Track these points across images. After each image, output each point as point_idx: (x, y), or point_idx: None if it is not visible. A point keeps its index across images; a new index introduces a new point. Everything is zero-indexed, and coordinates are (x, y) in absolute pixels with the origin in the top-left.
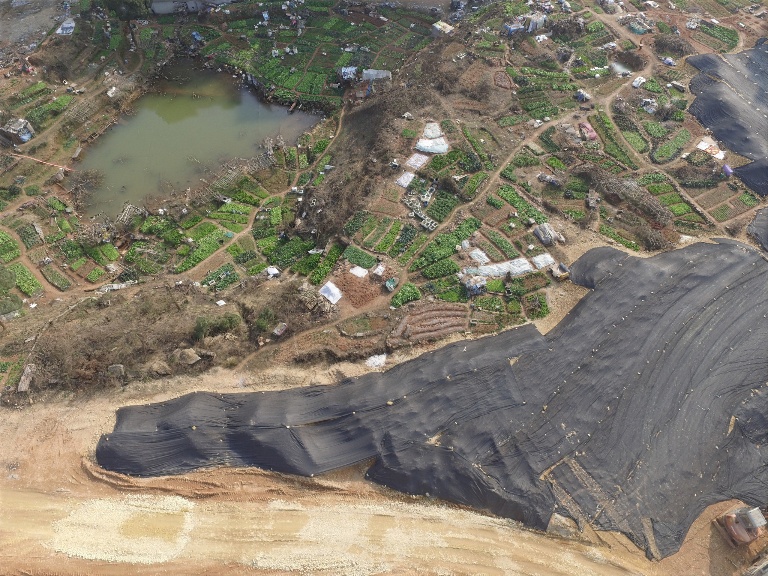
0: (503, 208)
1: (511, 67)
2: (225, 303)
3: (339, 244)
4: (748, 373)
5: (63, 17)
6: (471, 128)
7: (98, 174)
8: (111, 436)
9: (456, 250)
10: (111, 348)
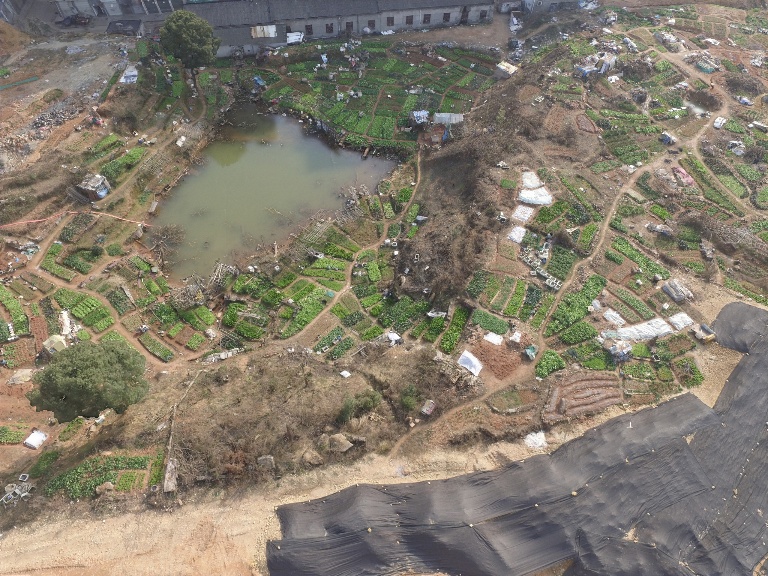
0: (624, 263)
1: (590, 110)
2: (350, 374)
3: (462, 306)
4: None
5: (122, 64)
6: (567, 176)
7: (178, 229)
8: (282, 544)
9: (589, 311)
10: (253, 436)
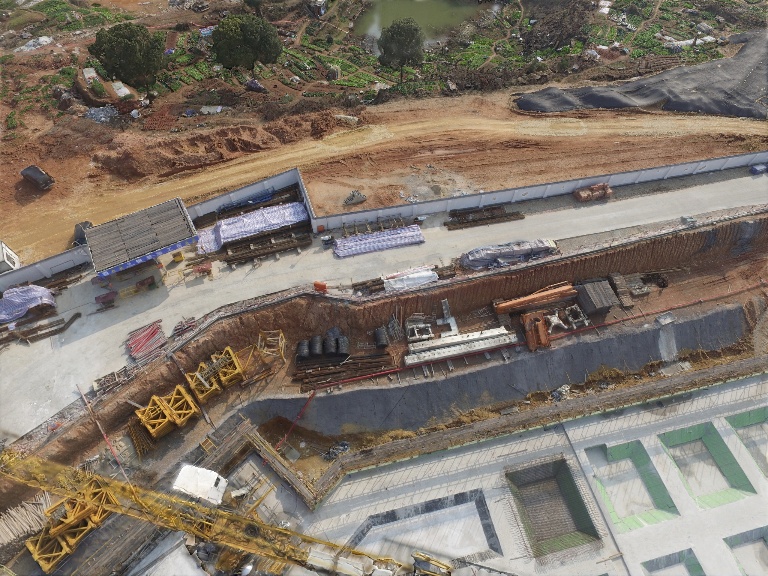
0: (672, 20)
1: None
2: None
3: None
4: None
5: None
6: None
7: (372, 35)
8: (523, 96)
9: (655, 37)
10: None
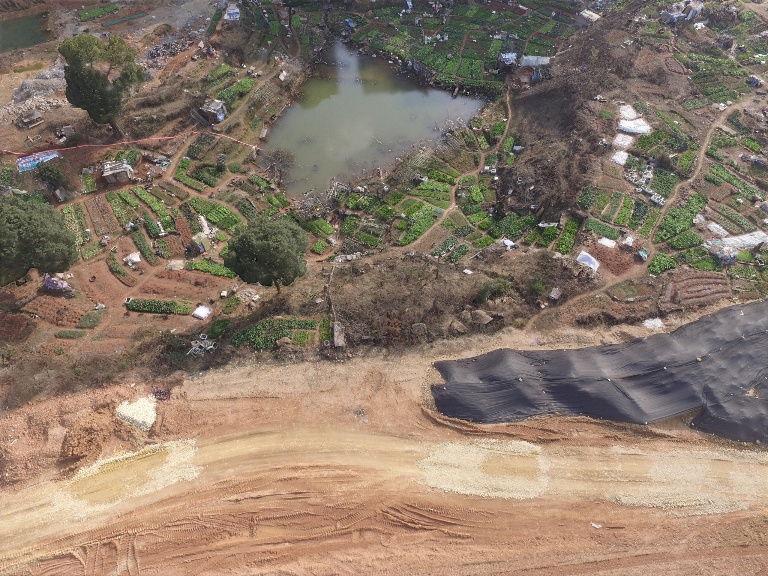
0: (723, 185)
1: (678, 53)
2: (472, 272)
3: (573, 217)
4: None
5: (221, 3)
6: (661, 111)
7: (289, 153)
8: (447, 386)
9: (694, 223)
10: (404, 309)
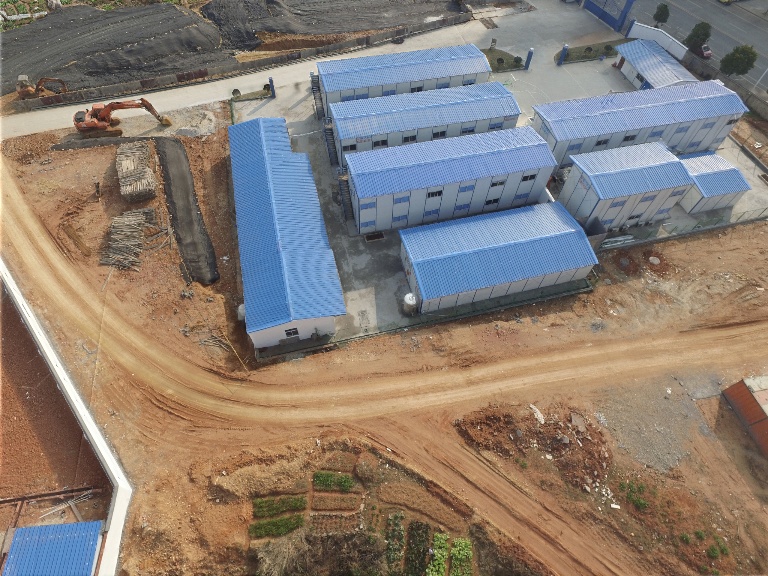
0: None
1: None
2: None
3: None
4: (105, 47)
5: None
6: None
7: None
8: None
9: None
10: None
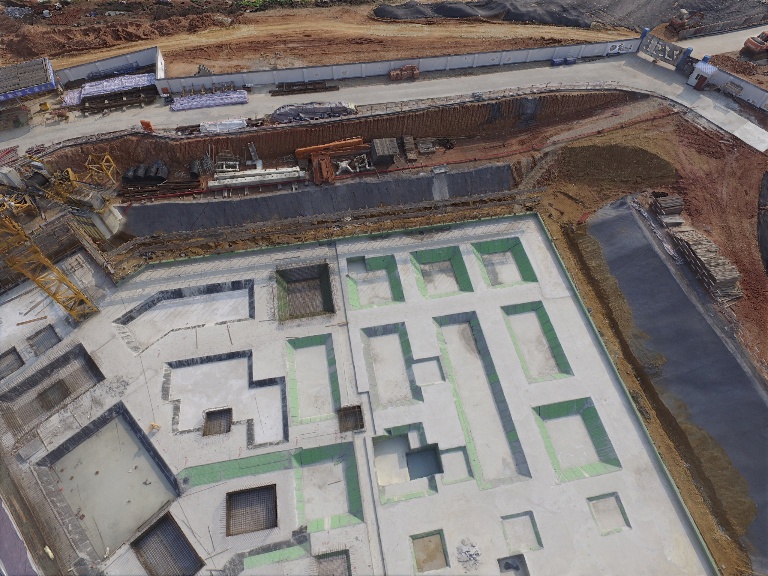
0: None
1: None
2: None
3: None
4: None
5: None
6: None
7: None
8: None
9: None
10: None
